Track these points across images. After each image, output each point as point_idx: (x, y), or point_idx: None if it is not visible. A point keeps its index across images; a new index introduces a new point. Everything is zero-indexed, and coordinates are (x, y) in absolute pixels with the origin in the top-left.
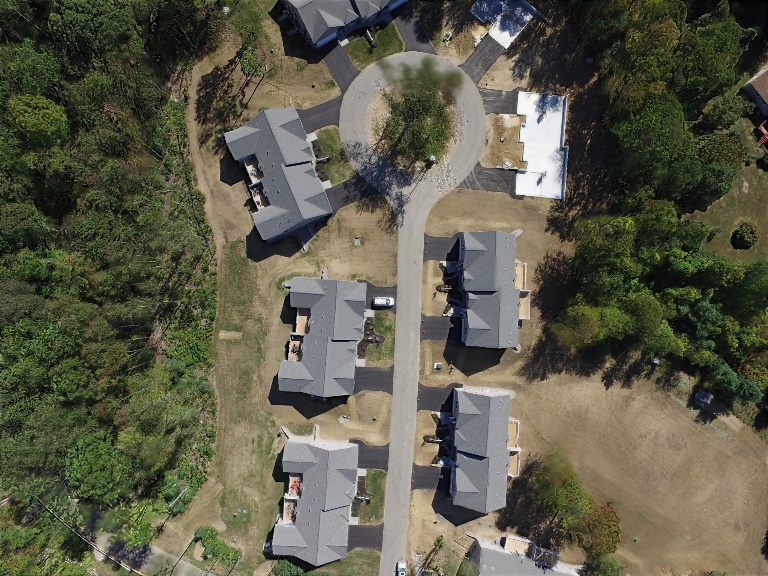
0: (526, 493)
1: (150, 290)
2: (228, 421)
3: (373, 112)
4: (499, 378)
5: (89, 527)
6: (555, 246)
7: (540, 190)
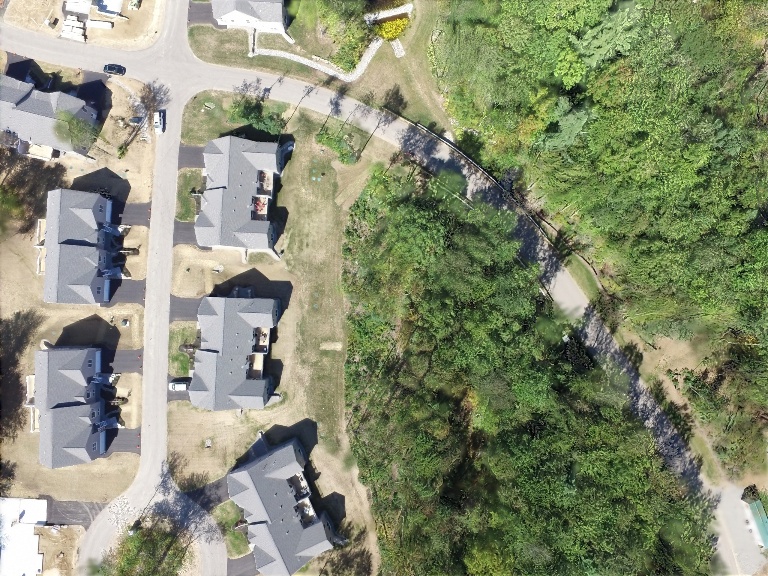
0: (35, 200)
1: (408, 387)
2: (332, 264)
3: (195, 575)
4: (63, 313)
5: (456, 164)
6: (6, 449)
7: (21, 506)
